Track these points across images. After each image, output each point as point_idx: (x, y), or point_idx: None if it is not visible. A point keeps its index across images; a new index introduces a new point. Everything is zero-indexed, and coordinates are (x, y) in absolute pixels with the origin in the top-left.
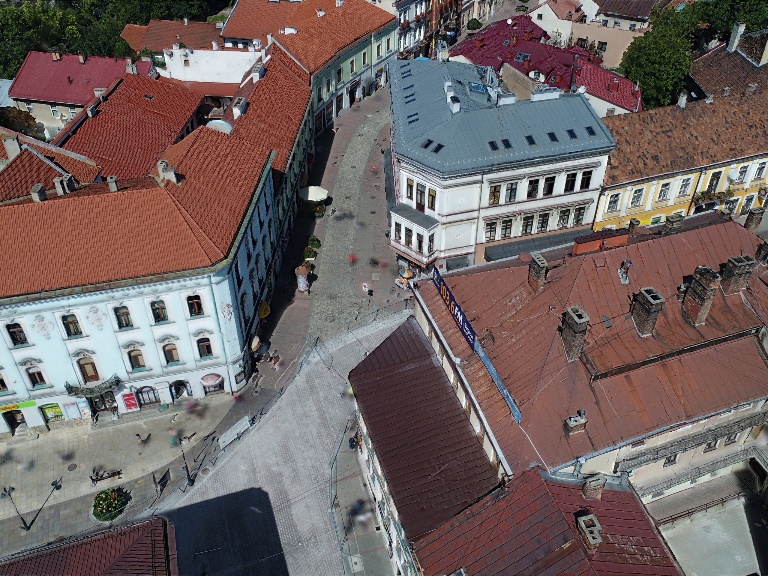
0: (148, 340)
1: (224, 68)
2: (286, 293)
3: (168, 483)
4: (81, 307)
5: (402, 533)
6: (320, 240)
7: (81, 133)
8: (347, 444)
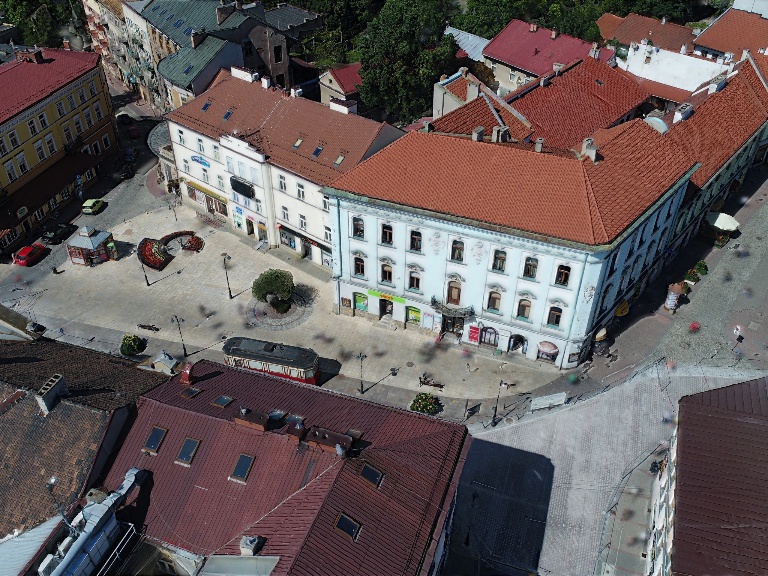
0: (511, 289)
1: (683, 73)
2: (650, 303)
3: (476, 414)
4: (471, 238)
5: (668, 566)
6: (709, 268)
7: (528, 98)
8: (648, 465)
